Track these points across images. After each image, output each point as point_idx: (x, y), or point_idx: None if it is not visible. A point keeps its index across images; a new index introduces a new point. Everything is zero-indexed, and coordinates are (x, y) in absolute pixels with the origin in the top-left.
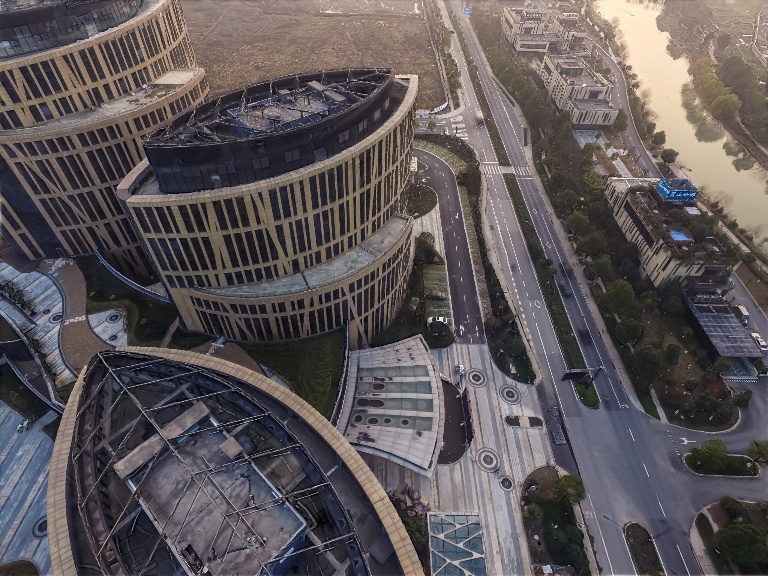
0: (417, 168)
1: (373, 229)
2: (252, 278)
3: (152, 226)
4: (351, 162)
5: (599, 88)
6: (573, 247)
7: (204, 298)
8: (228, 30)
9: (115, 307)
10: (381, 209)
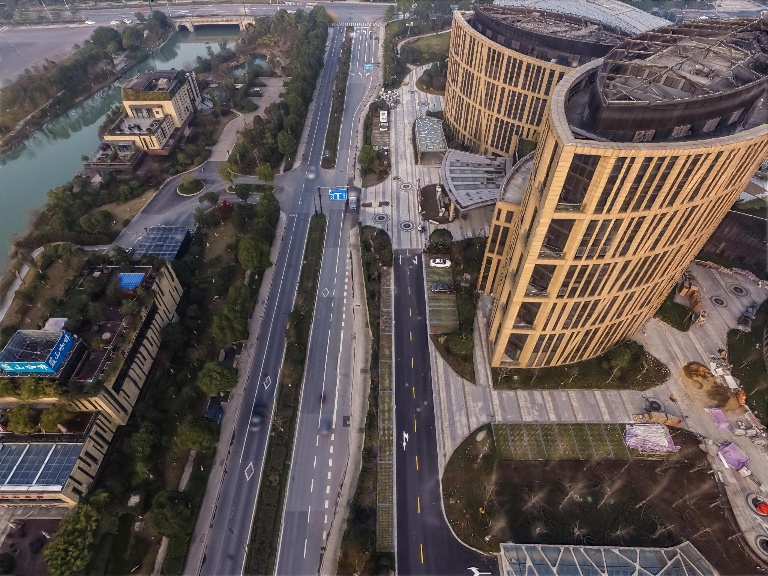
0: None
1: None
2: None
3: None
4: None
5: None
6: None
7: None
8: None
9: None
10: None
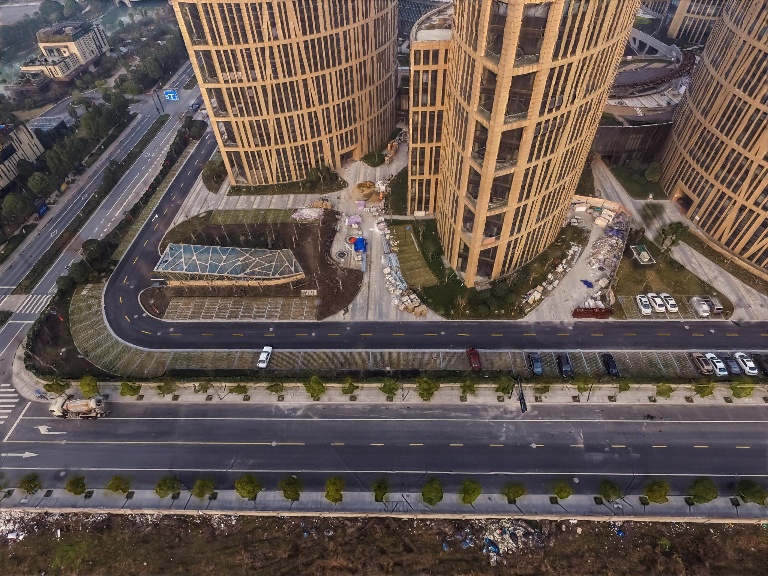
0: None
1: None
2: None
3: None
4: None
5: None
6: None
7: None
8: None
9: None
10: None
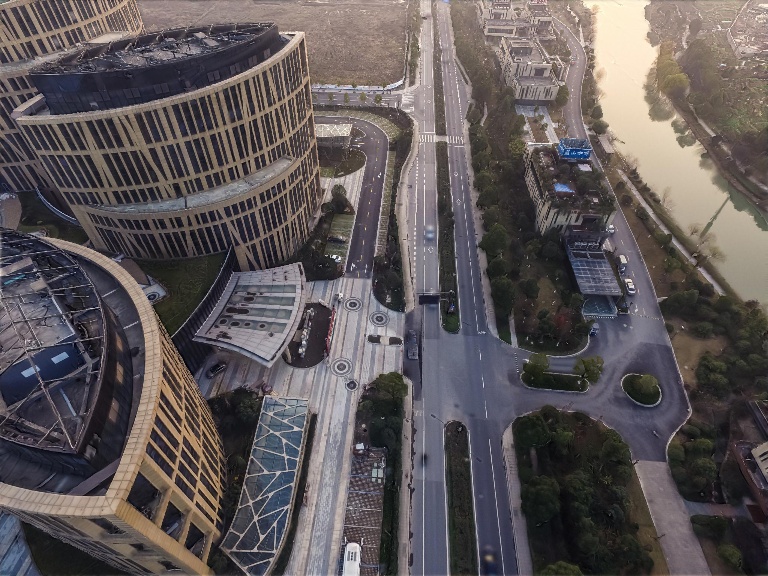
0: (354, 135)
1: (258, 166)
2: (138, 198)
3: (41, 143)
4: (214, 96)
5: (544, 65)
6: None
7: (97, 214)
8: (217, 18)
9: (40, 229)
10: (263, 148)
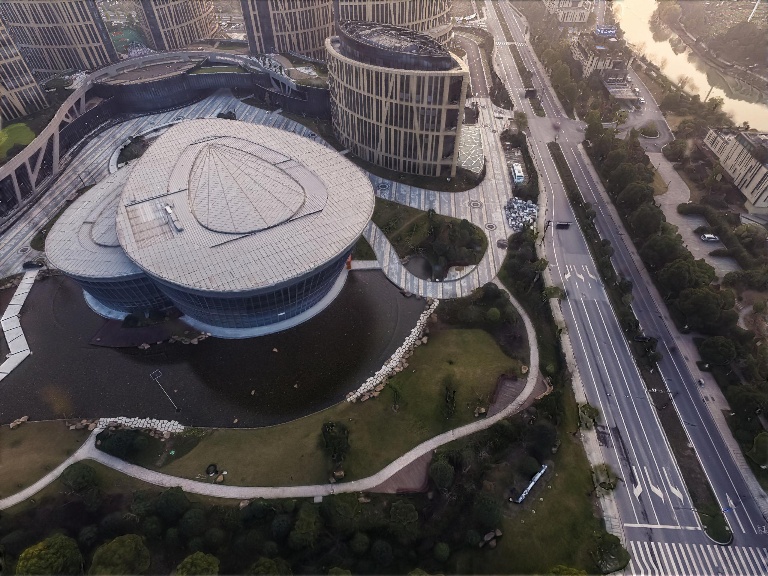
0: (454, 41)
1: (433, 25)
2: None
3: None
4: None
5: None
6: (546, 70)
7: None
8: None
9: (307, 65)
10: (437, 14)
